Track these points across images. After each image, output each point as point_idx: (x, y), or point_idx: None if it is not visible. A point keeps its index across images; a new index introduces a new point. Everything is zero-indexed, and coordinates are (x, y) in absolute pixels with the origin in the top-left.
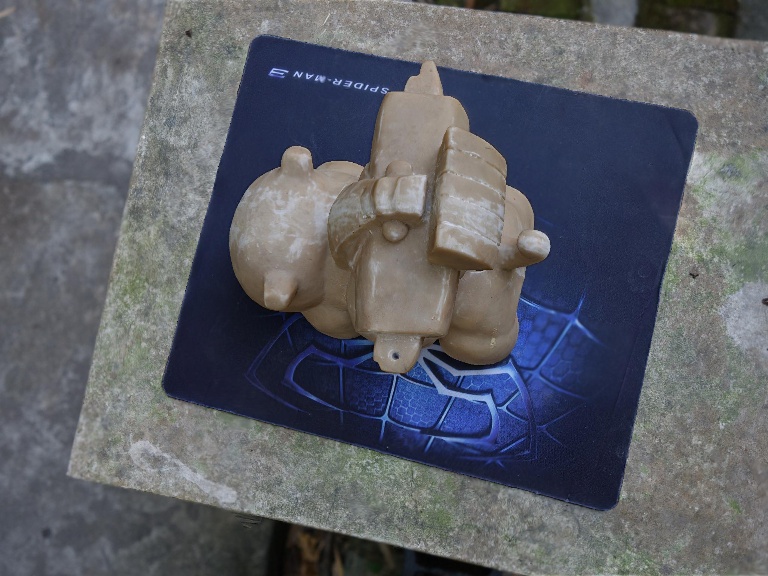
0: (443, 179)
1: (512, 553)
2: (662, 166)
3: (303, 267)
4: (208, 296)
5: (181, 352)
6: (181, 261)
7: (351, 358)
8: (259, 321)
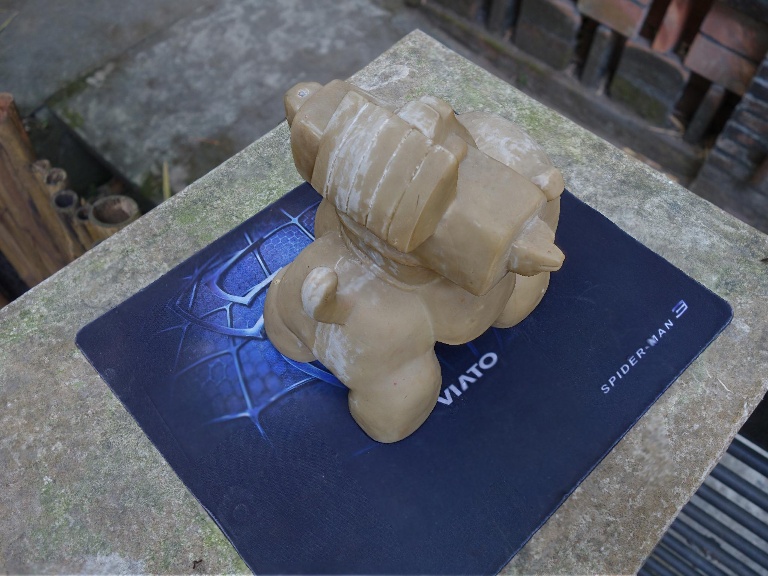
0: None
1: (118, 248)
2: None
3: None
4: None
5: None
6: None
7: None
8: None
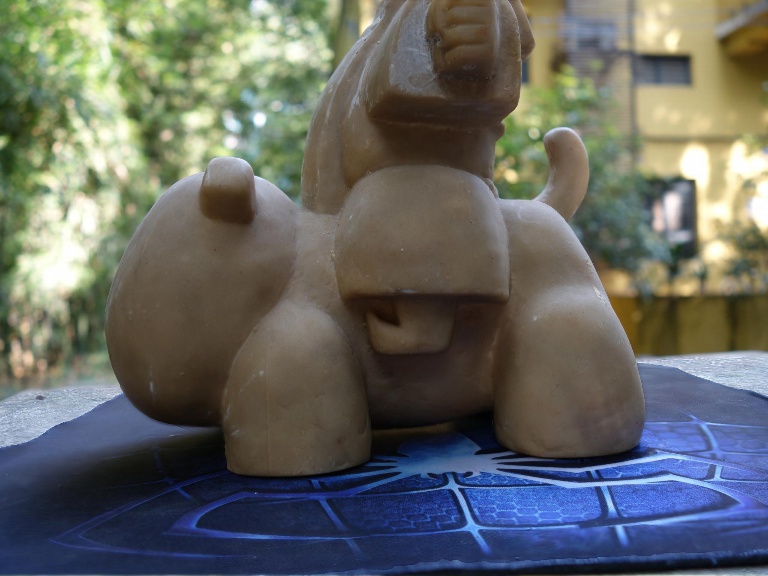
0: None
1: None
2: (656, 374)
3: (267, 190)
4: None
5: None
6: None
7: (341, 489)
8: (108, 491)
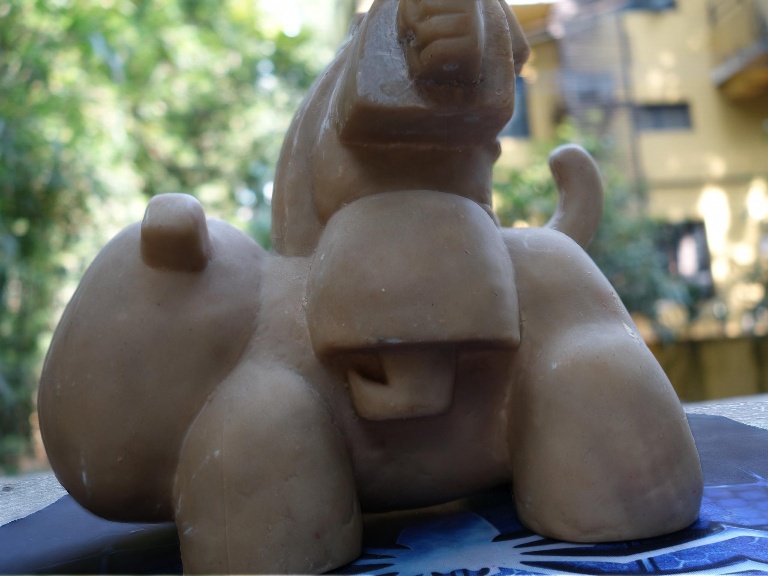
0: None
1: None
2: (701, 425)
3: (225, 232)
4: None
5: None
6: None
7: None
8: None
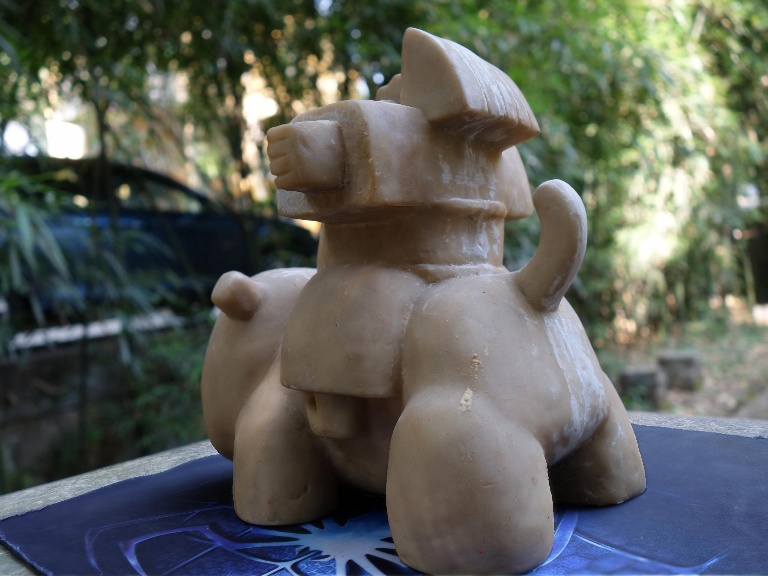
0: None
1: None
2: None
3: (281, 286)
4: (156, 484)
5: (62, 506)
6: None
7: (241, 542)
8: (178, 503)
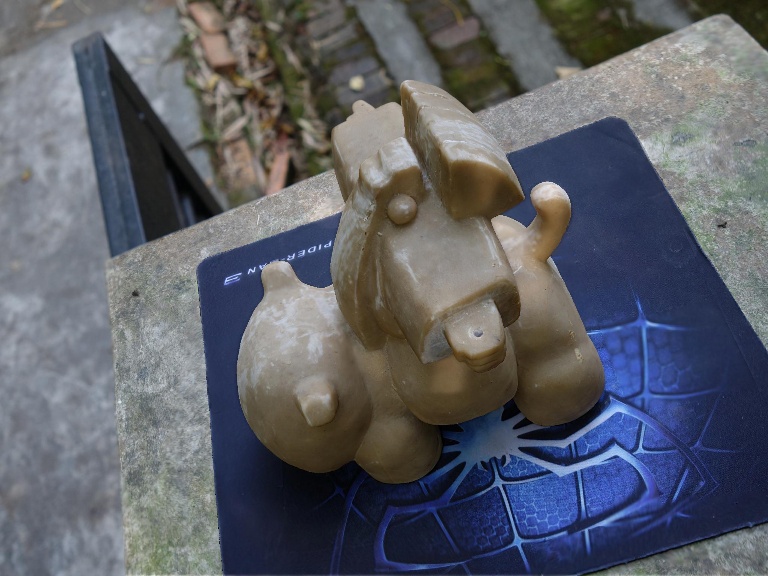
0: (421, 114)
1: None
2: (621, 163)
3: (332, 364)
4: (247, 520)
5: None
6: (202, 500)
7: (440, 495)
8: (316, 514)
